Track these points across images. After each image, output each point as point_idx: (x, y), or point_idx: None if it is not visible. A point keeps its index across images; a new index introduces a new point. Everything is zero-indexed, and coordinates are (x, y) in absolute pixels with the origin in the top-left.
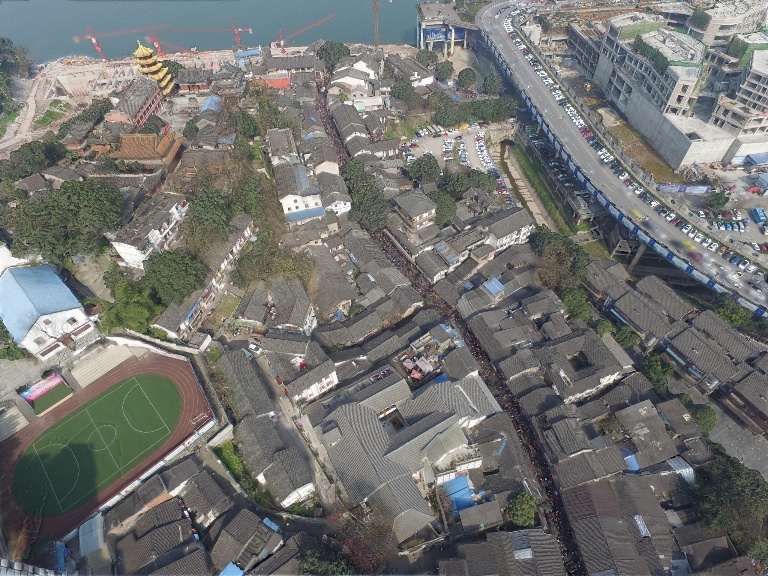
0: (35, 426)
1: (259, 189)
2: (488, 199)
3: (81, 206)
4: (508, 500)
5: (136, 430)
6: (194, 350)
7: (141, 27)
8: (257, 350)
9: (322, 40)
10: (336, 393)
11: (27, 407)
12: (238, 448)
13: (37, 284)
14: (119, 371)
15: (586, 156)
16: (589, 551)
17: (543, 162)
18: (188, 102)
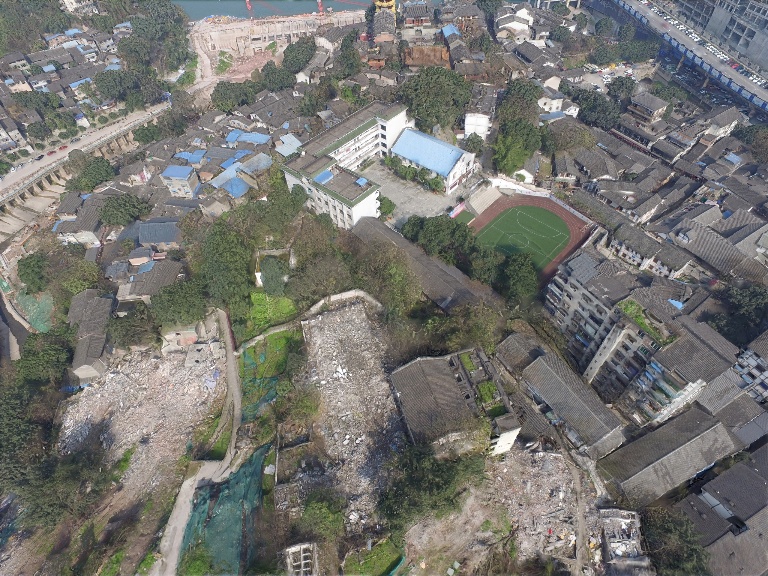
0: None
1: None
2: None
3: None
4: None
5: (541, 236)
6: None
7: None
8: None
9: None
10: (662, 219)
11: None
12: None
13: None
14: (498, 205)
15: (741, 81)
16: None
17: (693, 91)
18: (414, 34)
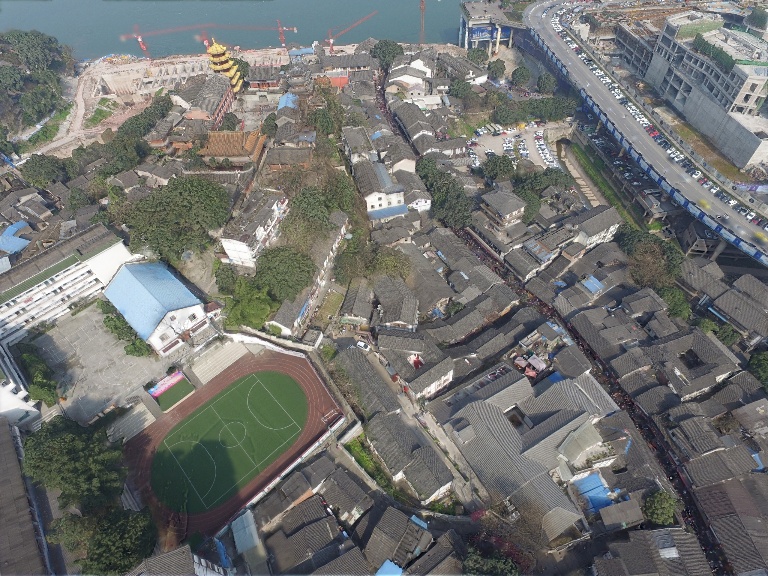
0: (162, 423)
1: (353, 186)
2: (570, 197)
3: (193, 202)
4: (643, 499)
5: (266, 427)
6: (309, 347)
7: (178, 26)
8: (366, 347)
9: (372, 39)
10: (455, 391)
11: (153, 403)
12: (364, 445)
13: (154, 280)
14: (237, 368)
15: (655, 155)
16: (734, 550)
17: (607, 161)
18: (258, 100)
